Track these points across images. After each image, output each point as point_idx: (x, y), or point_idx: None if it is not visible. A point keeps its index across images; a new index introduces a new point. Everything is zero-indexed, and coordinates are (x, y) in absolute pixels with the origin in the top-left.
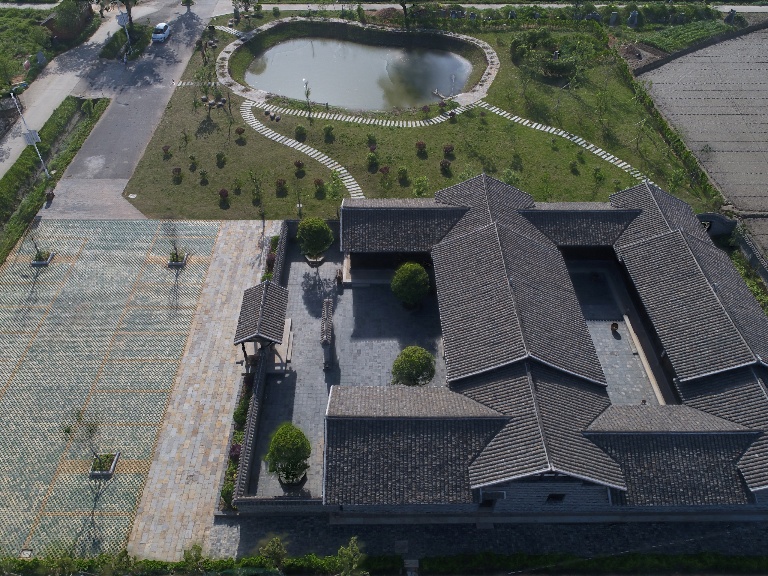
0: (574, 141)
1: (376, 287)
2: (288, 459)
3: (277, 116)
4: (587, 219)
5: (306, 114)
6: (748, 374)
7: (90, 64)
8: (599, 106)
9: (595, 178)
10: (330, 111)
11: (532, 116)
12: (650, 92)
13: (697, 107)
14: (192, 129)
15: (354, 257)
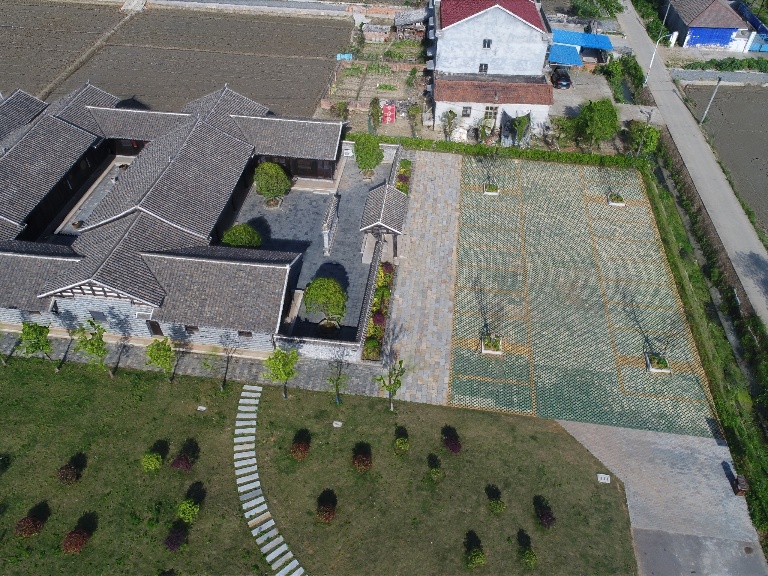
0: None
1: None
2: None
3: None
4: (13, 250)
5: None
6: None
7: None
8: None
9: None
10: None
11: None
12: None
13: None
14: None
15: None
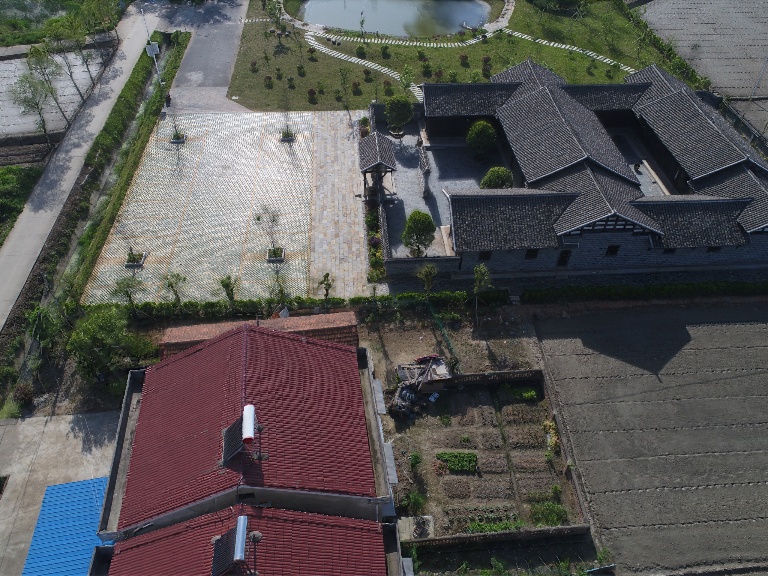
0: (586, 54)
1: (449, 149)
2: (423, 229)
3: (338, 41)
4: (611, 91)
5: (361, 40)
6: (741, 169)
7: (164, 8)
8: (605, 26)
9: (607, 78)
10: (381, 37)
11: (549, 37)
12: (643, 20)
13: (682, 30)
14: (269, 51)
15: (432, 126)
